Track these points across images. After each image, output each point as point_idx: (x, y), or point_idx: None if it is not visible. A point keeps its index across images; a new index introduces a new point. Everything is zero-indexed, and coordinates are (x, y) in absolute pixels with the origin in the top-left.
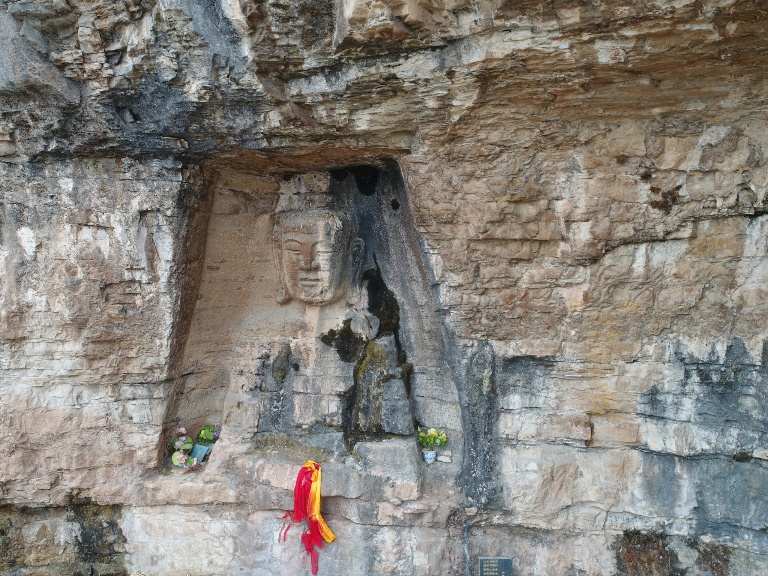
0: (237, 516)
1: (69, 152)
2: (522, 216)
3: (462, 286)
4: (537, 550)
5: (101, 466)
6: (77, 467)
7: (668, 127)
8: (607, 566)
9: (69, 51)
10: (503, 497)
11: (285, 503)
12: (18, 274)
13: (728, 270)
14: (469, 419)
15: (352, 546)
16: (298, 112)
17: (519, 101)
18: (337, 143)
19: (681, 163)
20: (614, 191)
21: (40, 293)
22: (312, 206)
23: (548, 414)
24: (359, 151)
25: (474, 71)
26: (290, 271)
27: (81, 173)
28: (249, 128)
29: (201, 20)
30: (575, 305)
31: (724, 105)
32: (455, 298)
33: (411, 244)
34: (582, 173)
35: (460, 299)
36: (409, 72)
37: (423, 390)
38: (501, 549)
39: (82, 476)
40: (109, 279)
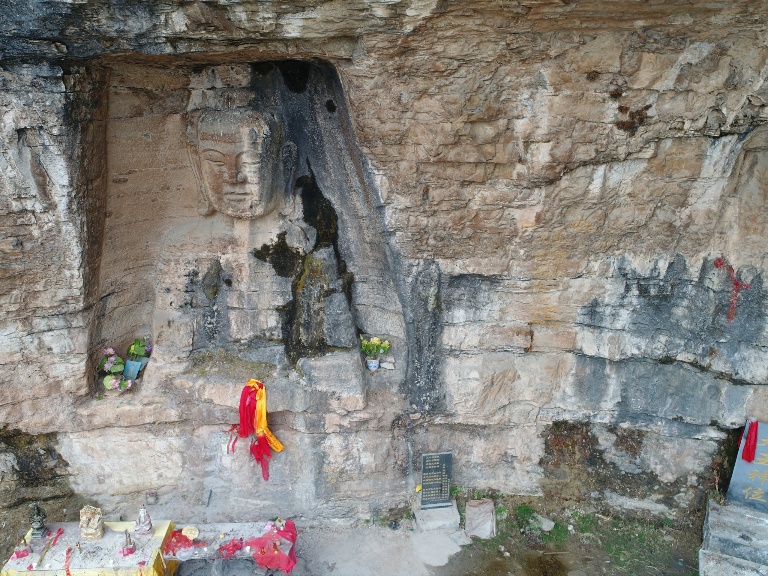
0: (182, 432)
1: None
2: (478, 137)
3: (409, 208)
4: (475, 442)
5: (26, 400)
6: None
7: (648, 42)
8: (536, 451)
9: None
10: (446, 403)
11: (230, 418)
12: None
13: (682, 190)
14: (414, 334)
15: (301, 454)
16: (209, 14)
17: (486, 11)
18: (261, 47)
19: (655, 82)
20: (580, 110)
21: None
22: (232, 106)
23: (491, 325)
24: (288, 54)
25: None
26: (213, 184)
27: None
28: (146, 31)
29: None
30: (526, 226)
31: (714, 21)
32: (401, 220)
33: (350, 152)
34: (547, 89)
35: (407, 221)
36: None
37: (365, 299)
38: (442, 443)
39: (6, 412)
40: None
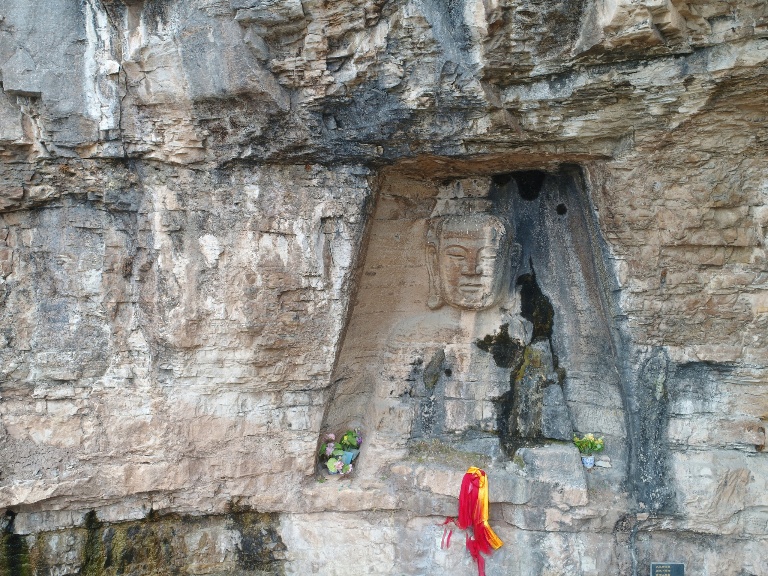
0: (396, 523)
1: (261, 159)
2: (720, 222)
3: (645, 292)
4: (705, 555)
5: (263, 474)
6: (241, 475)
7: None
8: None
9: (293, 58)
10: (676, 502)
11: (446, 509)
12: (199, 282)
13: None
14: (639, 424)
15: (520, 552)
16: (509, 119)
17: (745, 108)
18: (533, 149)
19: None
20: None
21: (219, 301)
22: (472, 211)
23: (719, 419)
24: (549, 157)
25: (716, 78)
26: (451, 277)
27: (268, 180)
28: (453, 135)
29: (439, 27)
30: (762, 311)
31: None
32: (636, 304)
33: (576, 249)
34: None
35: (642, 305)
36: (646, 79)
37: (576, 395)
38: (668, 554)
39: (245, 484)
40: (287, 286)
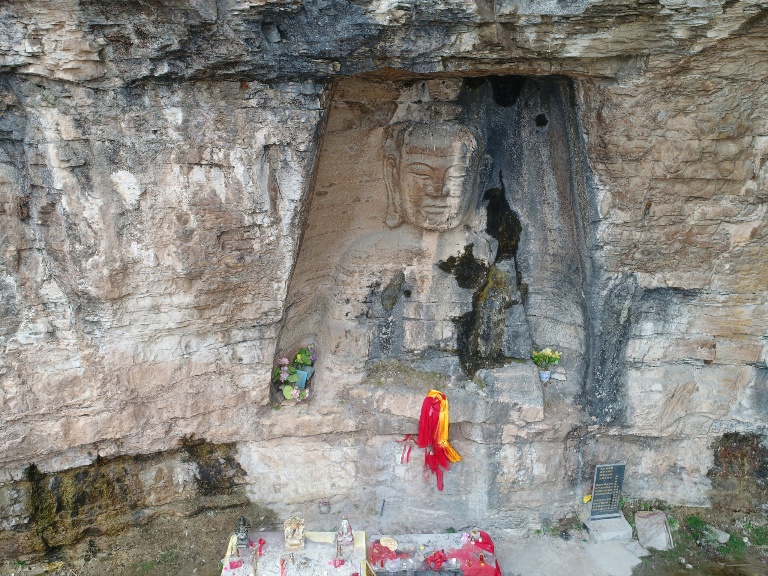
0: (356, 442)
1: (182, 76)
2: (719, 154)
3: (625, 223)
4: (644, 453)
5: (215, 410)
6: (192, 415)
7: None
8: (705, 462)
9: None
10: (626, 415)
11: (406, 428)
12: (118, 226)
13: None
14: (600, 346)
15: (477, 464)
16: (501, 34)
17: None
18: (523, 65)
19: None
20: None
21: (146, 246)
22: (439, 119)
23: (676, 338)
24: None
25: (764, 3)
26: (414, 197)
27: (192, 101)
28: (430, 51)
29: None
30: (739, 241)
31: None
32: (615, 235)
33: (553, 166)
34: None
35: (620, 236)
36: None
37: (536, 310)
38: (611, 454)
39: (198, 422)
40: (228, 226)
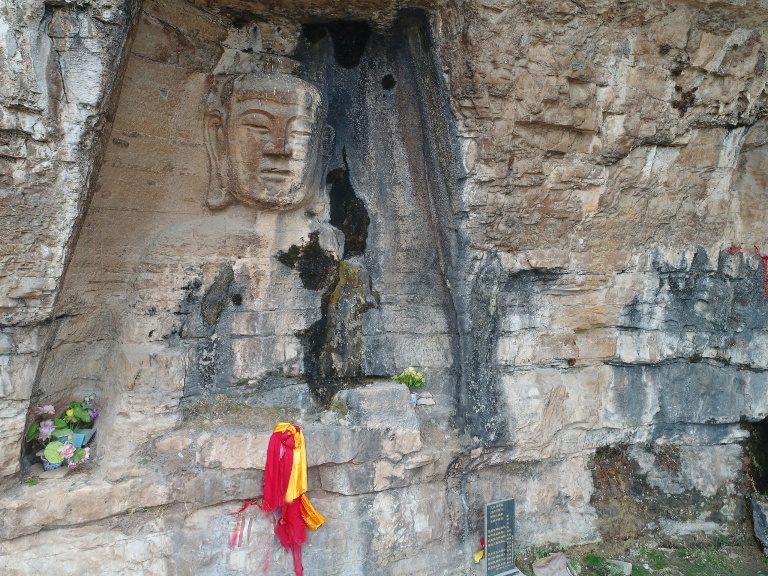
0: (167, 524)
1: None
2: (572, 99)
3: (490, 182)
4: (528, 485)
5: None
6: None
7: (711, 20)
8: (586, 487)
9: None
10: (509, 430)
11: (244, 489)
12: None
13: (703, 180)
14: (472, 346)
15: (347, 526)
16: None
17: None
18: None
19: (708, 62)
20: (649, 84)
21: None
22: (275, 70)
23: (541, 334)
24: None
25: None
26: (248, 157)
27: None
28: None
29: None
30: (590, 210)
31: (761, 5)
32: (480, 197)
33: (404, 136)
34: (629, 59)
35: (486, 198)
36: None
37: (391, 324)
38: (494, 492)
39: None
40: None
